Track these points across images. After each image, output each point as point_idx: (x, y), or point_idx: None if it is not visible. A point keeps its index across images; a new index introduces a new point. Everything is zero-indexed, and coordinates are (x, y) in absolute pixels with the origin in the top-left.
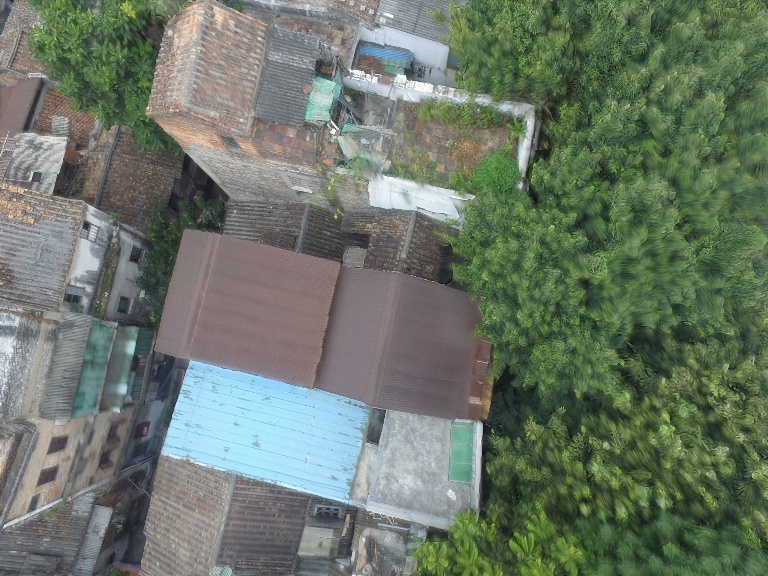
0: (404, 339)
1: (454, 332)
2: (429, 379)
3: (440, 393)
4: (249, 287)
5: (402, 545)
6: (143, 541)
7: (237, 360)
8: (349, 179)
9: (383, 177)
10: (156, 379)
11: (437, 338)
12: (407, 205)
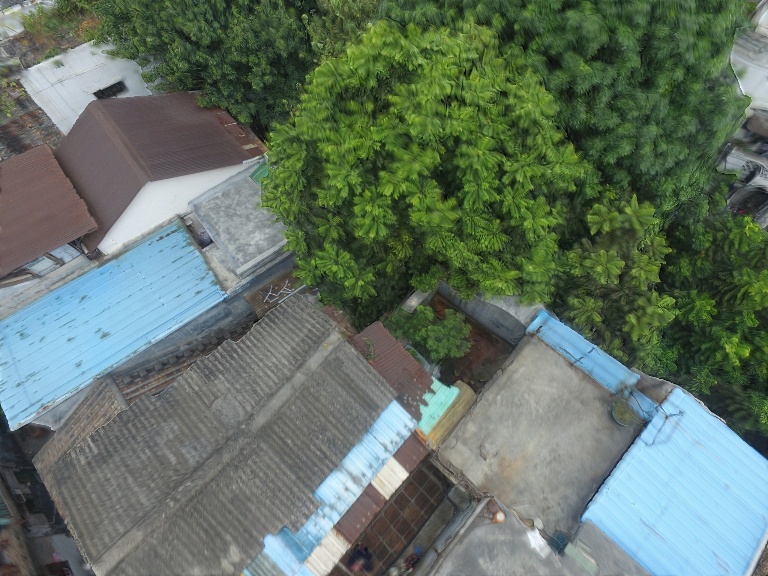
0: (140, 135)
1: (186, 118)
2: (191, 149)
3: (211, 153)
4: None
5: (312, 298)
6: None
7: (3, 262)
8: (3, 96)
9: (27, 69)
10: (33, 510)
11: (173, 125)
12: (86, 101)
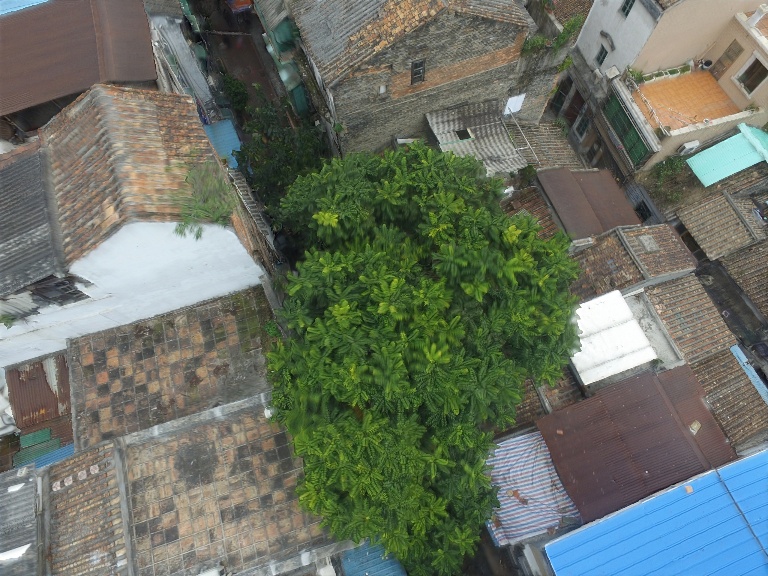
0: None
1: None
2: None
3: None
4: (51, 59)
5: None
6: (261, 33)
7: (39, 7)
8: None
9: None
10: None
11: None
12: None
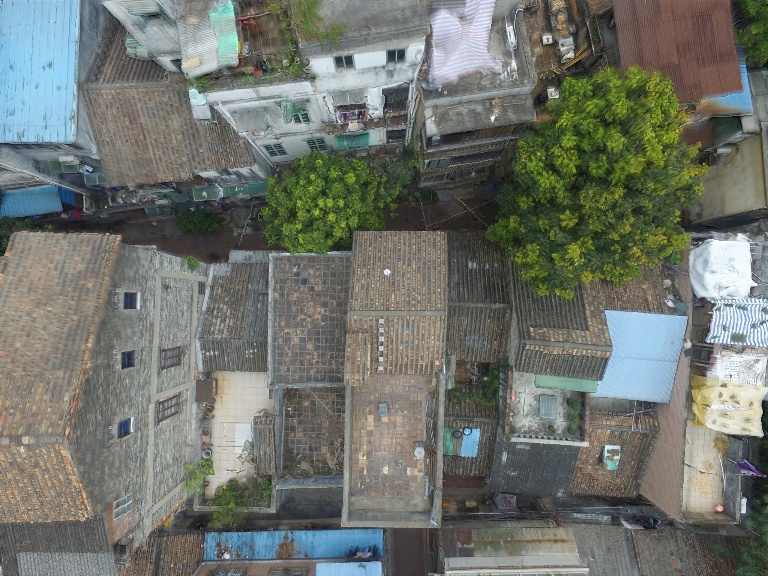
0: None
1: None
2: None
3: None
4: None
5: None
6: None
7: None
8: None
9: None
10: None
11: None
12: None
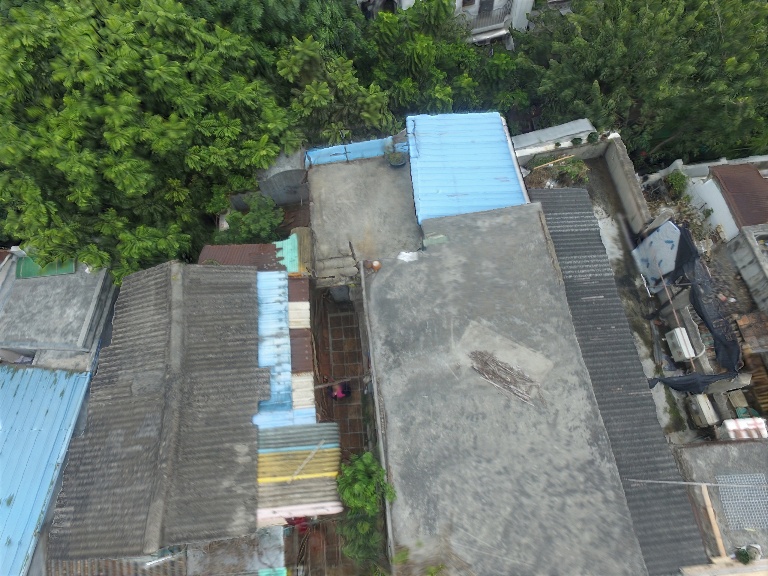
0: None
1: None
2: None
3: None
4: None
5: None
6: None
7: None
8: None
9: None
10: None
11: None
12: None
